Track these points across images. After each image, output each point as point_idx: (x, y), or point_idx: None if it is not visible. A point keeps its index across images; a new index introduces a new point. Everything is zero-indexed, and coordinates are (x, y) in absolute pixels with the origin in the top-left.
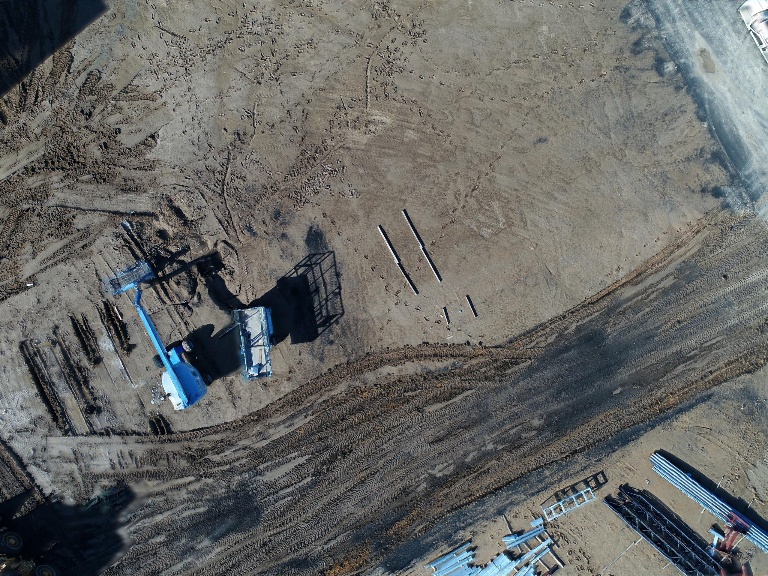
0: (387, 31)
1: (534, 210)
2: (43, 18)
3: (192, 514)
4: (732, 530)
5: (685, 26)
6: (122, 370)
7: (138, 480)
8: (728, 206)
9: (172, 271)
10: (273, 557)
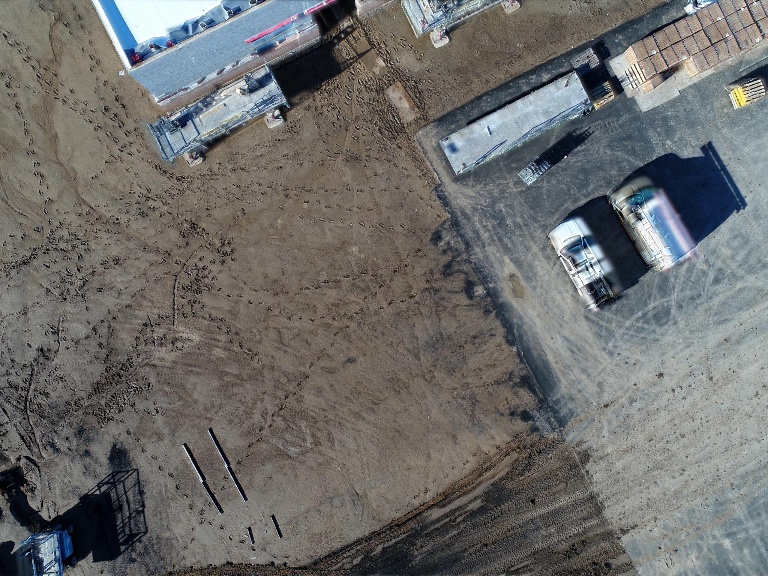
0: (195, 249)
1: (342, 430)
2: None
3: None
4: None
5: (494, 251)
6: None
7: None
8: (537, 430)
9: None
10: None
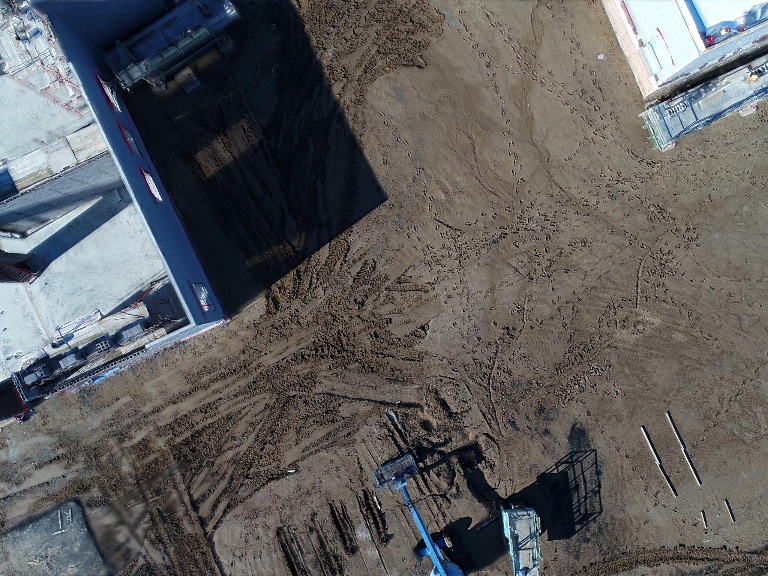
0: (661, 233)
1: None
2: (322, 205)
3: None
4: None
5: None
6: (378, 560)
7: None
8: None
9: (433, 462)
10: None
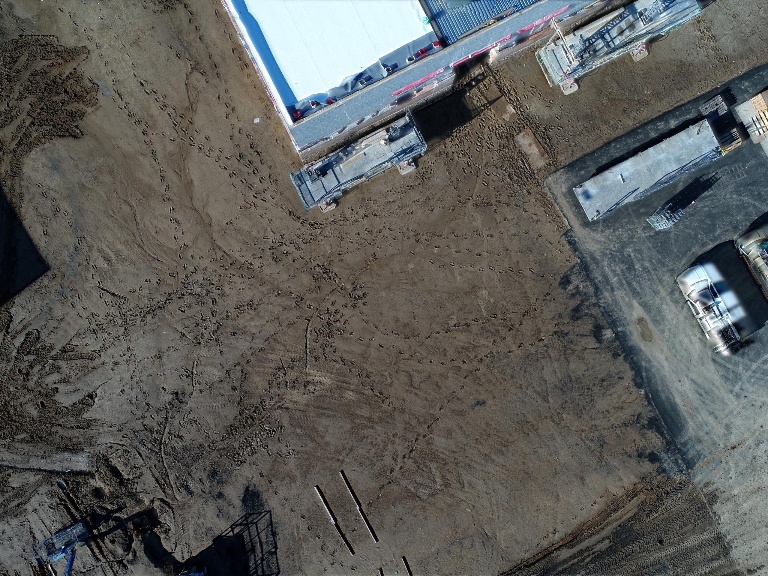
0: (327, 293)
1: (471, 472)
2: None
3: None
4: None
5: (623, 295)
6: None
7: None
8: (664, 472)
9: (107, 529)
10: None
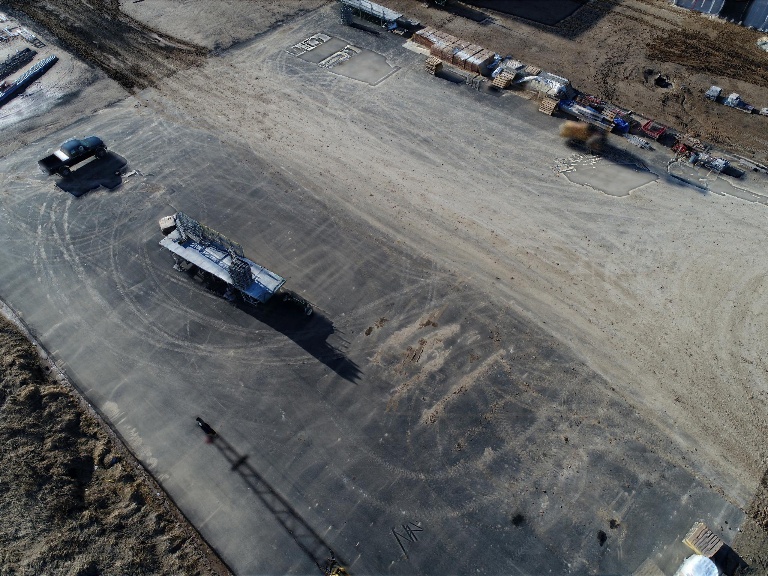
0: None
1: None
2: None
3: None
4: None
5: None
6: None
7: None
8: (210, 52)
9: None
10: None
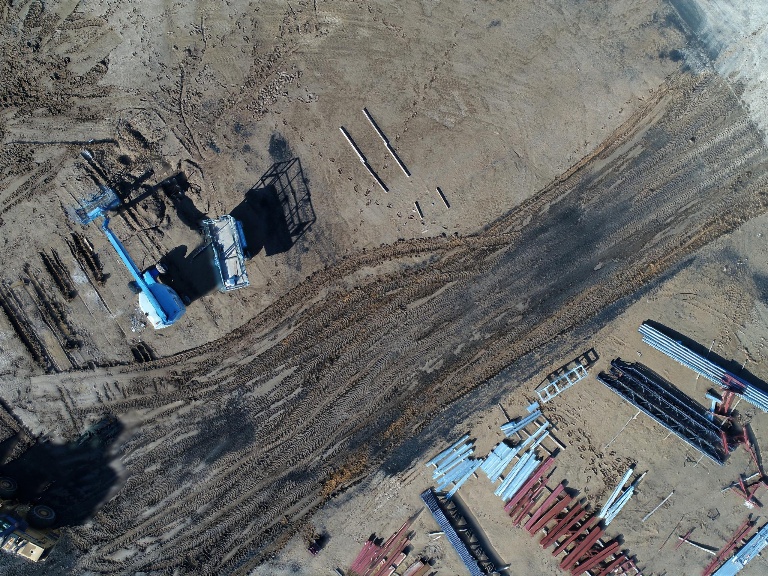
0: None
1: (495, 94)
2: None
3: (186, 438)
4: (729, 393)
5: None
6: (99, 301)
7: (127, 410)
8: (688, 69)
9: (138, 196)
10: (272, 472)
